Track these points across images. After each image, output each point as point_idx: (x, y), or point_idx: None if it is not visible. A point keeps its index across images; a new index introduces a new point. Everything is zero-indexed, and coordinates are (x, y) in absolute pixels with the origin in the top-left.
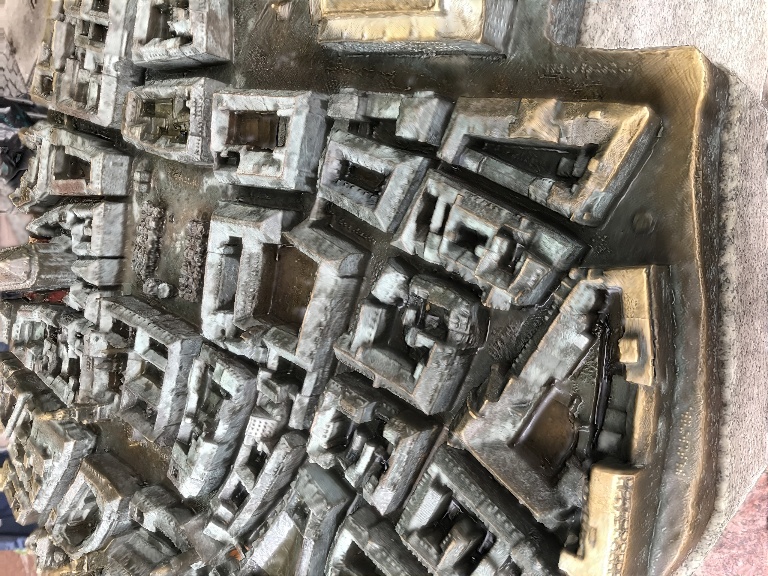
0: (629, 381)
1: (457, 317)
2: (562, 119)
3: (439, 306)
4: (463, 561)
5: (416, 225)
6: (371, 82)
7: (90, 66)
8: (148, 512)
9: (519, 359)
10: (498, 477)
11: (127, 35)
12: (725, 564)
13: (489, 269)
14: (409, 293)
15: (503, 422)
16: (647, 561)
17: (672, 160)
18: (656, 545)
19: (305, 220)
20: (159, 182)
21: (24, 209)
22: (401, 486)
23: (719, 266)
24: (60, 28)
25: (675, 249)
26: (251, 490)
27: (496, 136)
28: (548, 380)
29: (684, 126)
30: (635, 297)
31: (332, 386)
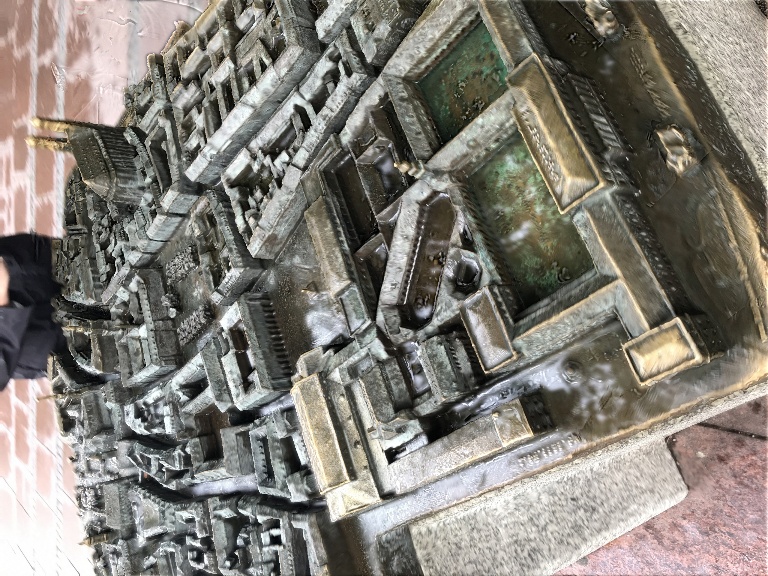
0: None
1: (254, 571)
2: None
3: None
4: None
5: None
6: None
7: (200, 123)
8: (110, 402)
9: None
10: None
11: (231, 142)
12: None
13: None
14: None
15: None
16: None
17: None
18: None
19: (237, 427)
20: None
21: None
22: None
23: None
24: (199, 54)
25: None
26: (152, 475)
27: None
28: None
29: None
30: None
31: (199, 509)
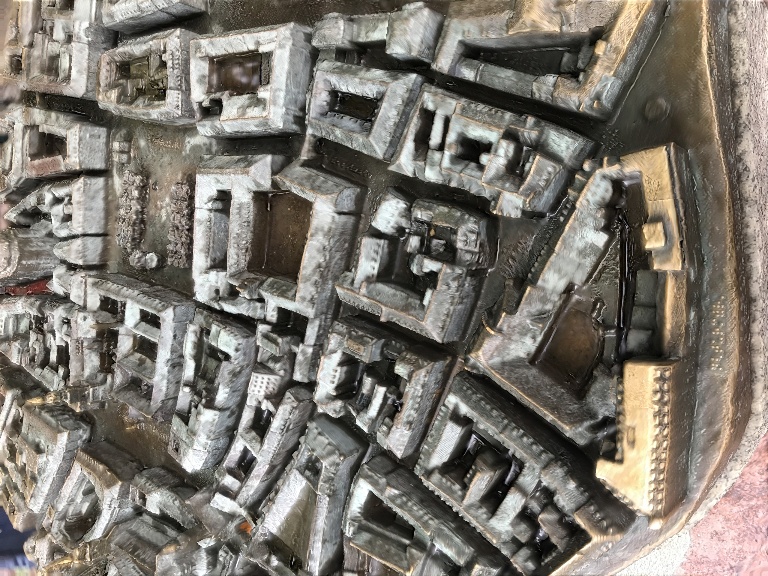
0: (657, 269)
1: (465, 234)
2: (563, 5)
3: (445, 226)
4: (489, 496)
5: (414, 144)
6: (355, 9)
7: (59, 36)
8: (150, 493)
9: (535, 268)
10: (522, 394)
11: None
12: (745, 517)
13: (496, 175)
14: (412, 219)
15: (523, 337)
16: (687, 467)
17: (682, 39)
18: (696, 449)
19: (296, 160)
20: (139, 151)
21: (0, 198)
22: (417, 426)
23: (737, 155)
24: (26, 2)
25: (693, 132)
26: (258, 453)
27: (493, 36)
28: (567, 287)
29: (692, 1)
30: (657, 178)
31: (337, 327)
